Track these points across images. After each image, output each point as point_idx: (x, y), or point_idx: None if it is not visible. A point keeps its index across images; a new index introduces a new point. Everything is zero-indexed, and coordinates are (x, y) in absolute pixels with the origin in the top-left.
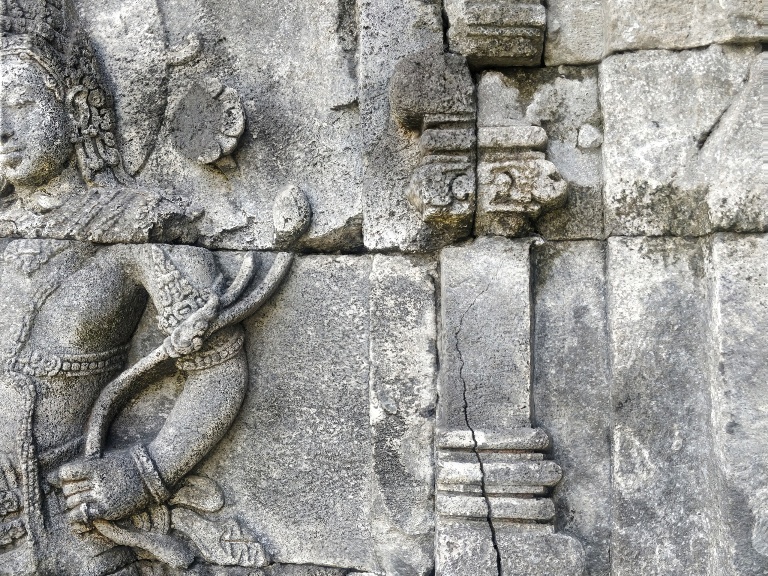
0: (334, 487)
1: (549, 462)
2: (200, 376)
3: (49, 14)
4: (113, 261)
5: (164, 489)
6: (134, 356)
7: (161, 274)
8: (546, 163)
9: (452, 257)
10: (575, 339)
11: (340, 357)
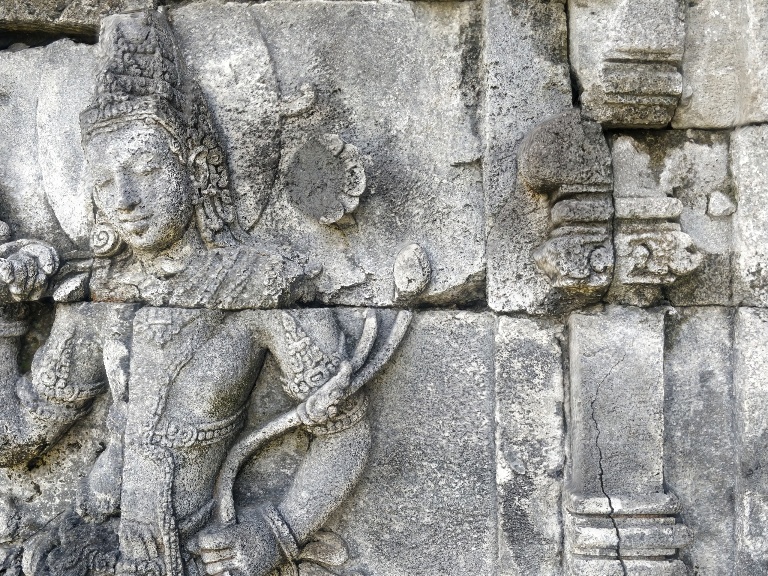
0: (457, 539)
1: (682, 526)
2: (331, 440)
3: (166, 70)
4: (242, 328)
5: (298, 550)
6: (254, 413)
7: (292, 341)
8: (683, 236)
9: (586, 326)
10: (701, 403)
11: (461, 413)
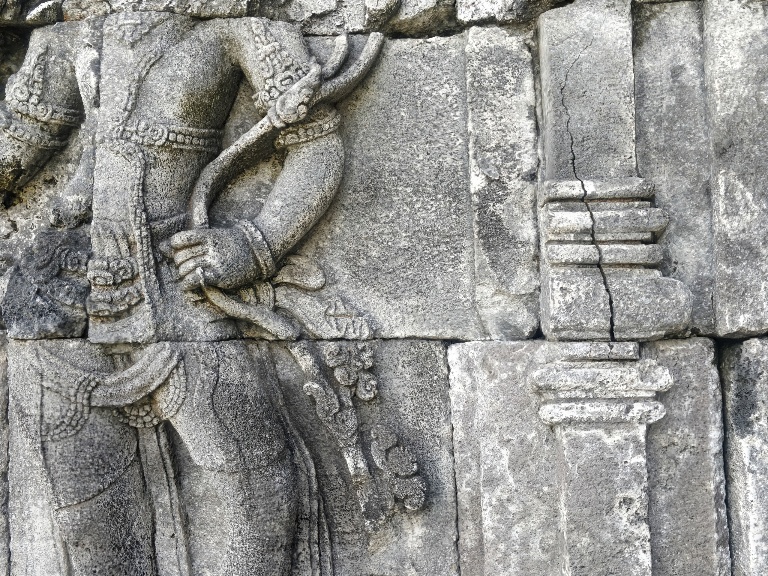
0: (434, 261)
1: (656, 208)
2: (303, 149)
3: None
4: (212, 35)
5: (272, 260)
6: (228, 143)
7: (262, 45)
8: None
9: (553, 17)
10: (673, 98)
11: (435, 136)
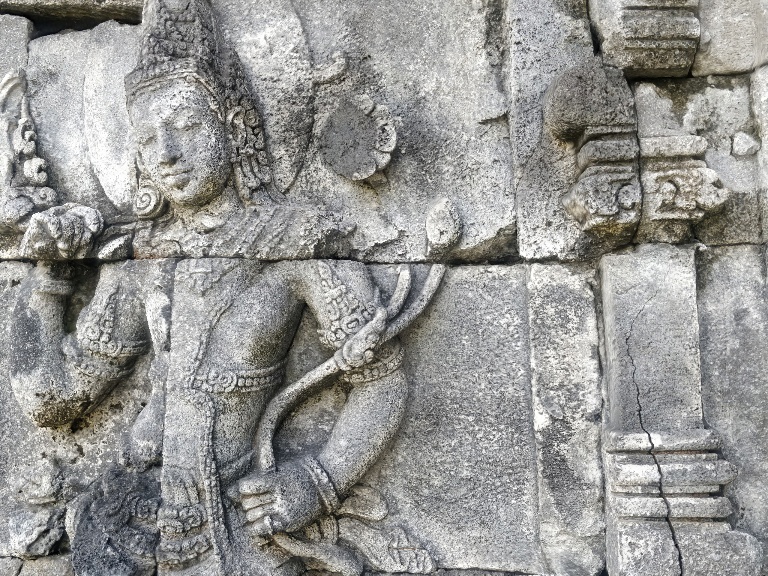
0: (496, 492)
1: (724, 462)
2: (368, 388)
3: (205, 37)
4: (280, 278)
5: (337, 500)
6: (291, 370)
7: (329, 289)
8: (709, 171)
9: (617, 265)
10: (737, 341)
11: (496, 365)
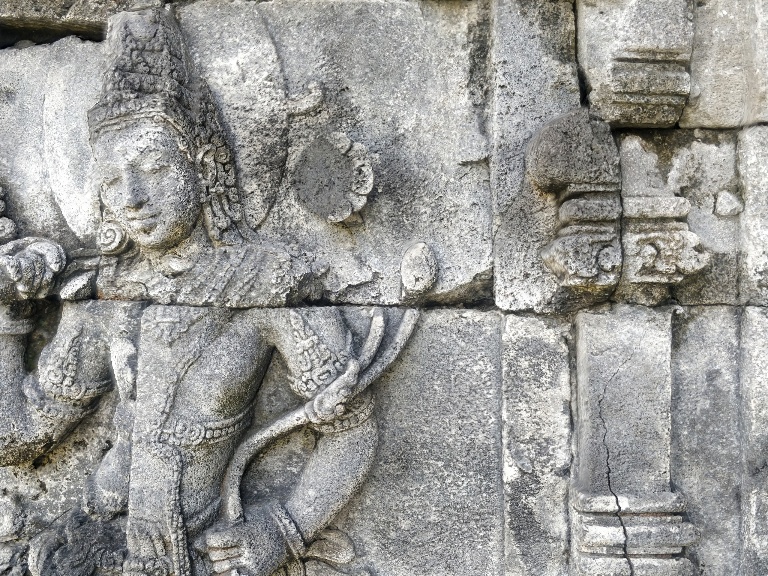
0: (463, 538)
1: (688, 525)
2: (338, 438)
3: (174, 68)
4: (250, 326)
5: (305, 548)
6: (260, 411)
7: (300, 340)
8: (691, 235)
9: (593, 325)
10: (707, 402)
11: (467, 412)
